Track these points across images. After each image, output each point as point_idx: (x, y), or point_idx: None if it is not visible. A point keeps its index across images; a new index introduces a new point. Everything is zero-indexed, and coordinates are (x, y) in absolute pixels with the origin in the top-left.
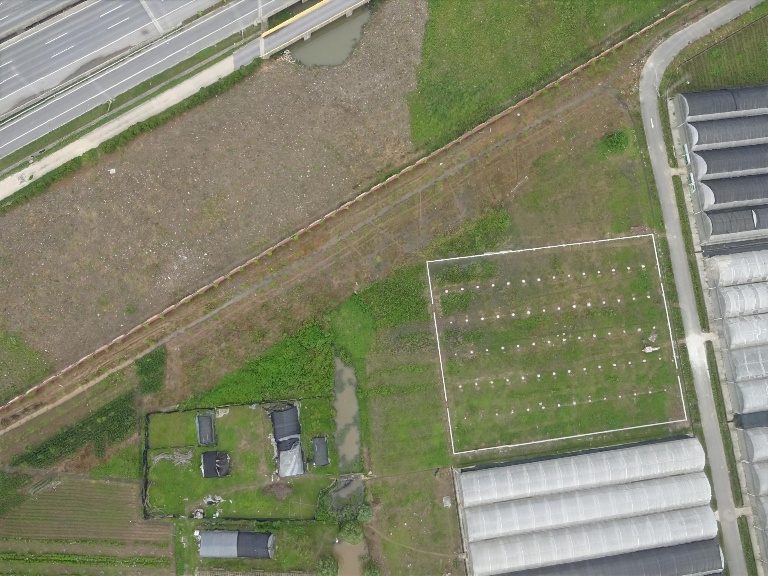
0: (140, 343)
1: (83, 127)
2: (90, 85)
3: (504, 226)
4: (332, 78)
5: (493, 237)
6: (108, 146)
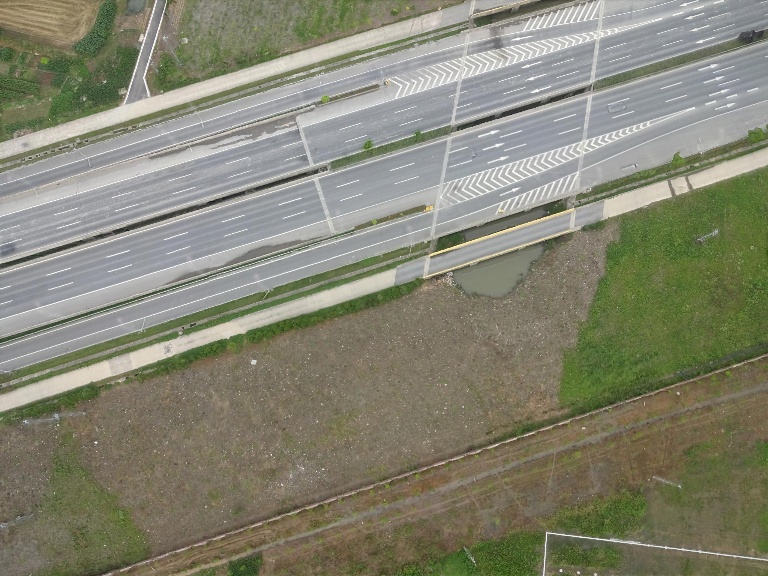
0: (238, 545)
1: (236, 309)
2: (253, 270)
3: (638, 514)
4: (490, 313)
5: (624, 523)
6: (256, 337)
